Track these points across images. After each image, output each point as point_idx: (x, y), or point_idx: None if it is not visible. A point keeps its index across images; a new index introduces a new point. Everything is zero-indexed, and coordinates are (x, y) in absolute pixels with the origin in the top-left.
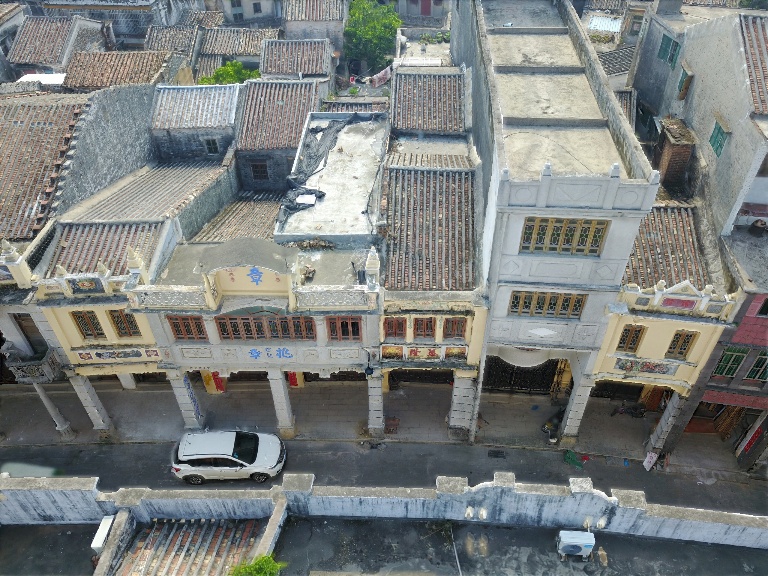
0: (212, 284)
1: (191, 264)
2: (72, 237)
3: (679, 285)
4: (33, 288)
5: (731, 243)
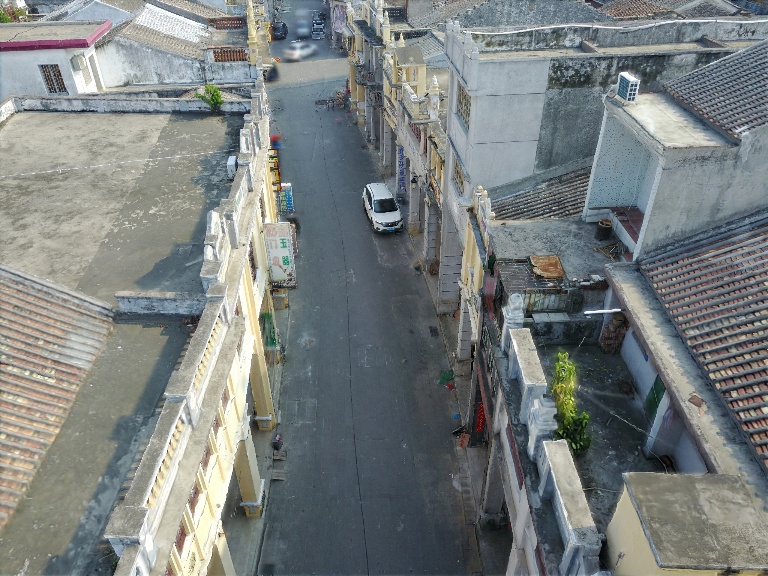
0: (398, 66)
1: (431, 74)
2: (427, 40)
3: None
4: (384, 45)
5: (568, 220)
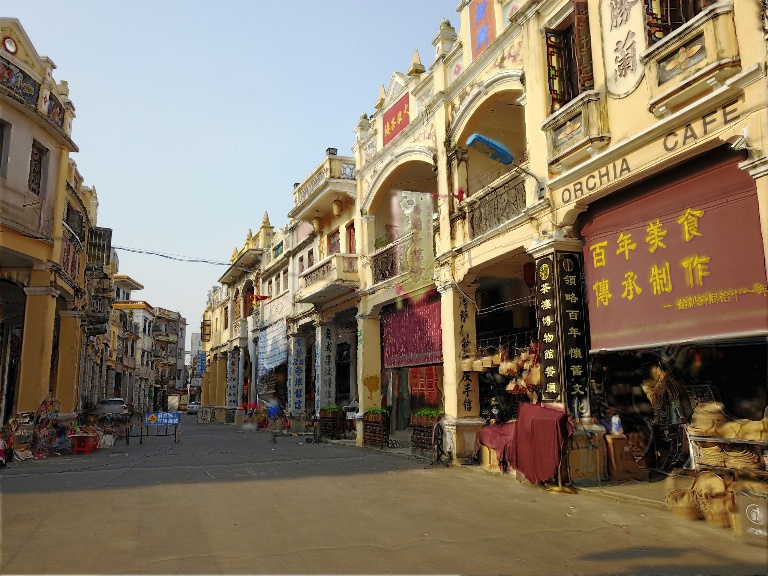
0: None
1: None
2: None
3: (113, 309)
4: None
5: None
